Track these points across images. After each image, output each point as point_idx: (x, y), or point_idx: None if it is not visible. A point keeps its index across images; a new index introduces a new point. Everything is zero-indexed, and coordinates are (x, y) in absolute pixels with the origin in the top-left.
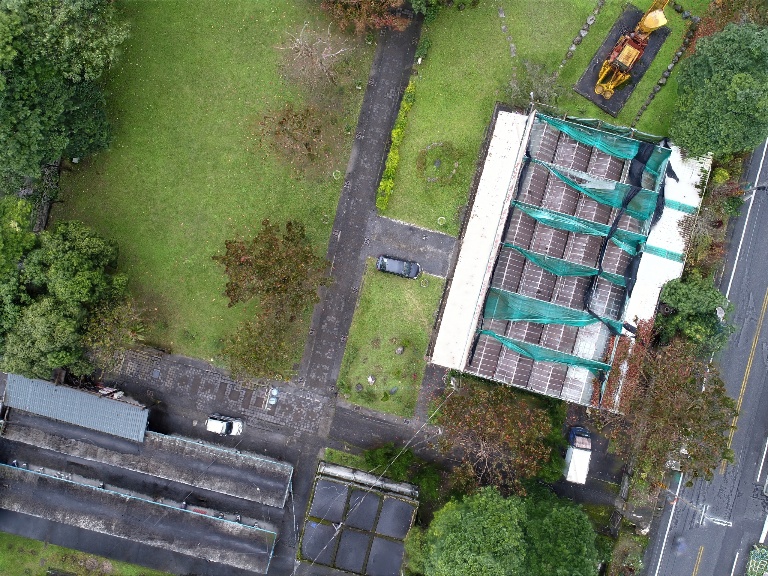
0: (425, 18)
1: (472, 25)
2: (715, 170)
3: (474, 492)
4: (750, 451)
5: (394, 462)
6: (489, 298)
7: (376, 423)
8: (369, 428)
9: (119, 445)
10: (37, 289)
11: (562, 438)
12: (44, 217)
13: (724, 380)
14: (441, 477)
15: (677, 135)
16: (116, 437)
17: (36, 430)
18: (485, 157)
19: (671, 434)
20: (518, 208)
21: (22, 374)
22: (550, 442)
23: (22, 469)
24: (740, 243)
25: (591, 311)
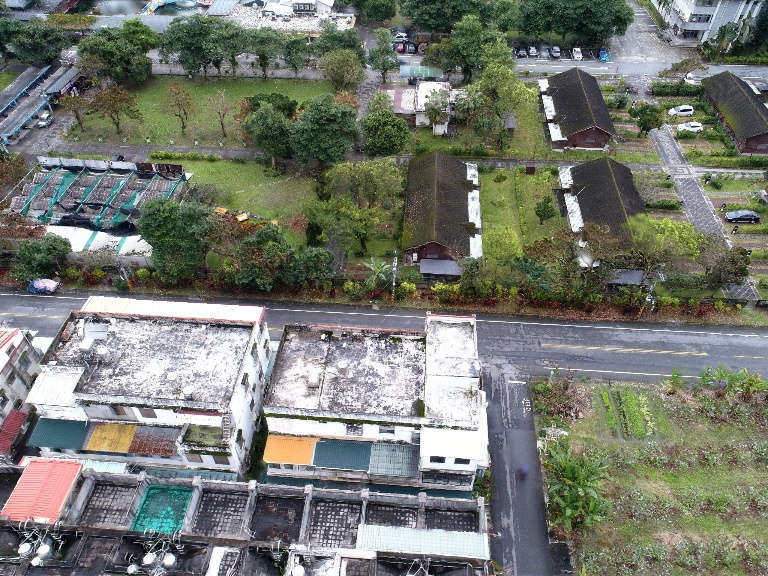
0: None
1: (255, 176)
2: (148, 271)
3: None
4: None
5: None
6: None
7: None
8: None
9: None
10: None
11: None
12: None
13: None
14: None
15: None
16: None
17: (62, 73)
18: None
19: None
20: None
21: None
22: None
23: (44, 71)
24: None
25: None
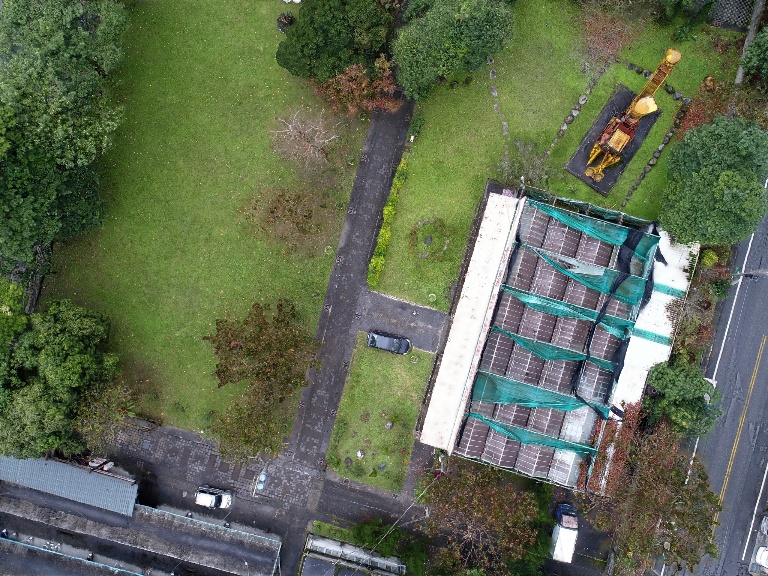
0: (418, 96)
1: (465, 103)
2: (704, 252)
3: (460, 575)
4: (735, 530)
5: (381, 542)
6: (478, 380)
7: (365, 497)
8: (357, 501)
9: (108, 518)
10: (28, 372)
11: (549, 517)
12: (37, 287)
13: (710, 459)
14: (428, 551)
15: (666, 222)
16: (105, 510)
17: (26, 502)
18: (476, 234)
19: (655, 528)
20: (507, 291)
21: (12, 455)
22: (537, 523)
23: (11, 541)
24: (728, 323)
25: (578, 395)
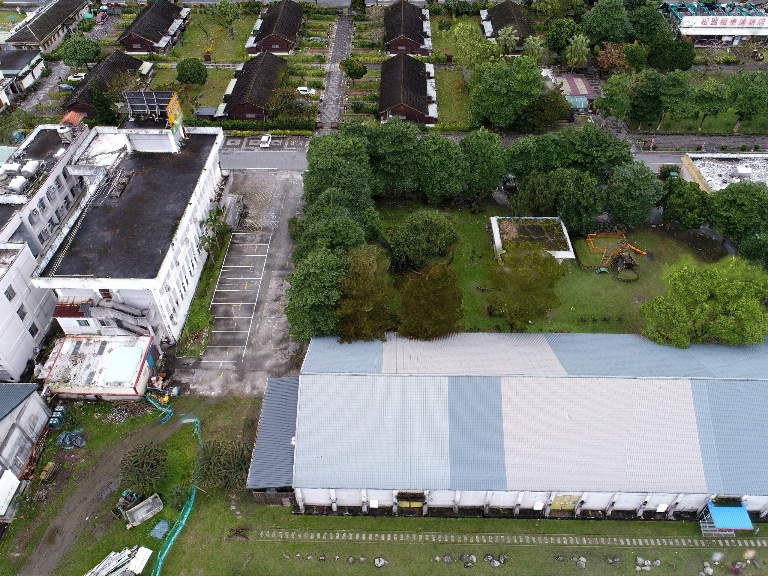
0: None
1: None
2: None
3: None
4: None
5: None
6: None
7: None
8: None
9: None
10: None
11: None
12: None
13: None
14: None
15: (659, 3)
16: None
17: None
18: None
19: None
20: None
21: None
22: None
23: None
24: None
25: None
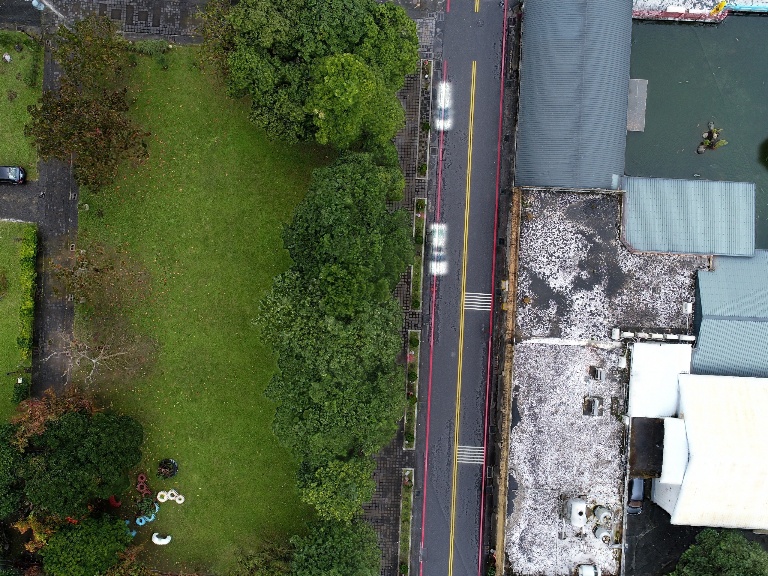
0: None
1: None
2: None
3: None
4: None
5: None
6: None
7: None
8: (3, 11)
9: None
10: (294, 58)
11: None
12: None
13: None
14: None
15: None
16: None
17: None
18: None
19: None
20: None
21: None
22: None
23: None
24: None
25: None
